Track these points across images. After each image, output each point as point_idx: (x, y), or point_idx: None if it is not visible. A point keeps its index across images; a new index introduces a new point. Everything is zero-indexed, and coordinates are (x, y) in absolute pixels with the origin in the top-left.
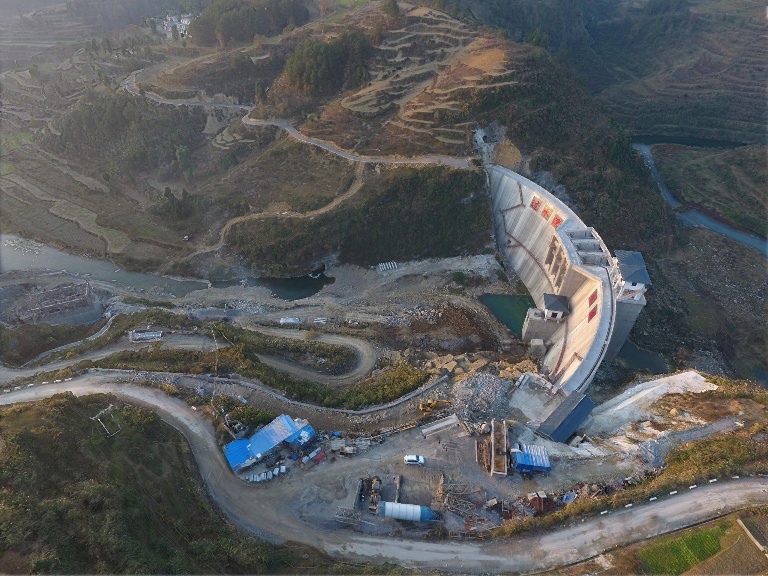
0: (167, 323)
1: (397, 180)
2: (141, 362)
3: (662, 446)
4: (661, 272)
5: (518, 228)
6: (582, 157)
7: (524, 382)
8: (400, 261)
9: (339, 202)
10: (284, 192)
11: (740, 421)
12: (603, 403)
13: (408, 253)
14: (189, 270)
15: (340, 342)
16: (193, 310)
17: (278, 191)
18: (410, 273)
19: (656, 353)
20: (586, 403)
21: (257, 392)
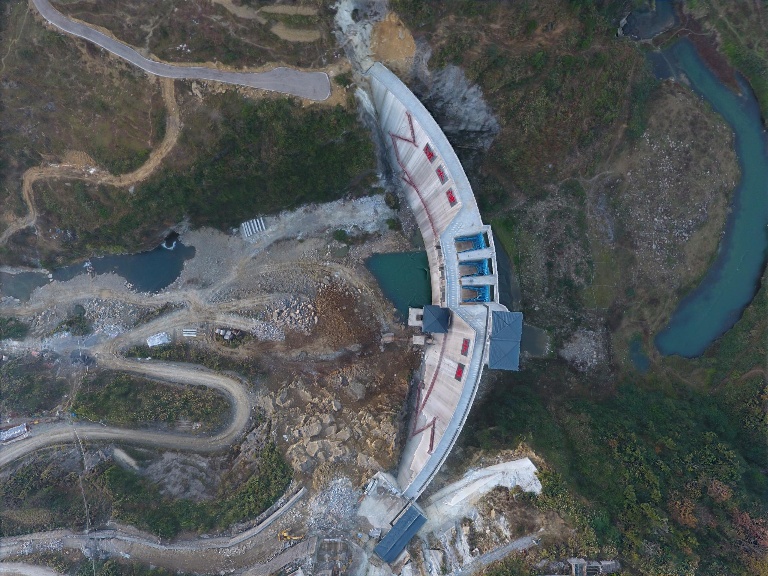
0: (25, 412)
1: (228, 130)
2: (21, 510)
3: (464, 574)
4: (583, 212)
5: (412, 166)
6: (518, 20)
7: (372, 490)
8: (268, 214)
9: (158, 162)
10: (75, 132)
11: (537, 538)
12: (443, 490)
13: (275, 205)
14: (15, 258)
15: (213, 383)
16: (47, 342)
17: (66, 129)
18: (282, 236)
19: (541, 330)
20: (419, 521)
21: (135, 546)
